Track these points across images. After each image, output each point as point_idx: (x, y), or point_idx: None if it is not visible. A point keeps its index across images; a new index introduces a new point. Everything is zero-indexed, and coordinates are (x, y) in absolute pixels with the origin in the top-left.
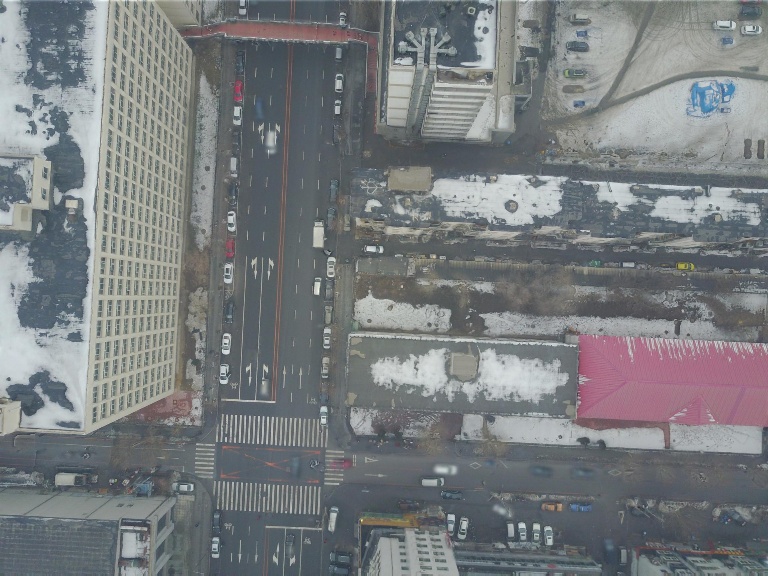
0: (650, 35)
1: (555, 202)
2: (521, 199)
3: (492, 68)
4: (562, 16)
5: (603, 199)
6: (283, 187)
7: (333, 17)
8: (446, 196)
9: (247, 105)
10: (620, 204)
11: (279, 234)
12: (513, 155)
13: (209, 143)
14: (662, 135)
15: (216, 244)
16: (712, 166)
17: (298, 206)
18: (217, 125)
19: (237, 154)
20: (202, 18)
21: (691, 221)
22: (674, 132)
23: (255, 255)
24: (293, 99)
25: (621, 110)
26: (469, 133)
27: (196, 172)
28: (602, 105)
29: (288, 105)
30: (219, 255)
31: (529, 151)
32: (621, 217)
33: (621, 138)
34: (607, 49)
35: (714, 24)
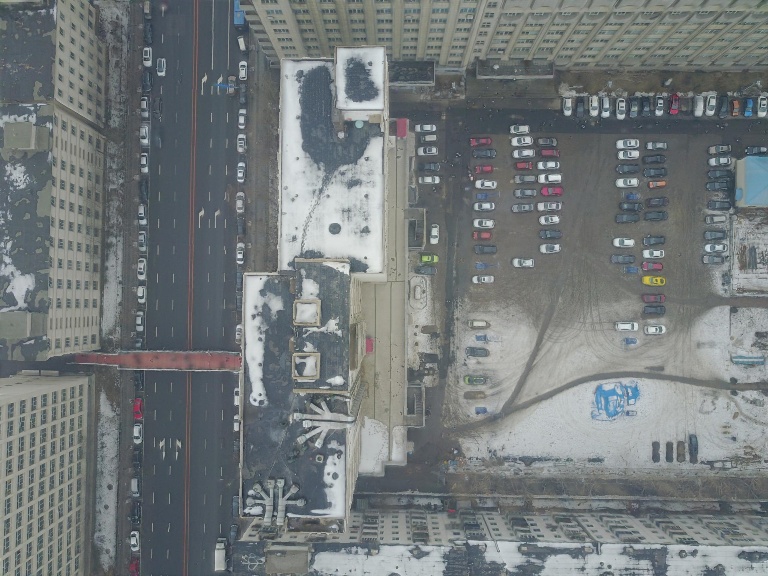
0: (551, 337)
1: (439, 573)
2: (404, 571)
3: (342, 516)
4: (461, 320)
5: (491, 560)
6: (186, 503)
7: (230, 328)
8: (328, 570)
9: (147, 421)
10: (508, 565)
11: (183, 552)
12: (416, 465)
13: (111, 461)
14: (567, 440)
15: (120, 565)
16: (619, 471)
17: (201, 522)
18: (118, 443)
19: (139, 471)
20: (100, 335)
21: None
22: (579, 437)
23: (160, 573)
24: (193, 413)
25: (524, 415)
26: (363, 466)
27: (99, 491)
28: (505, 411)
29: (188, 420)
30: (124, 575)
31: (432, 460)
32: None
33: (525, 444)
34: (508, 353)
35: (615, 327)
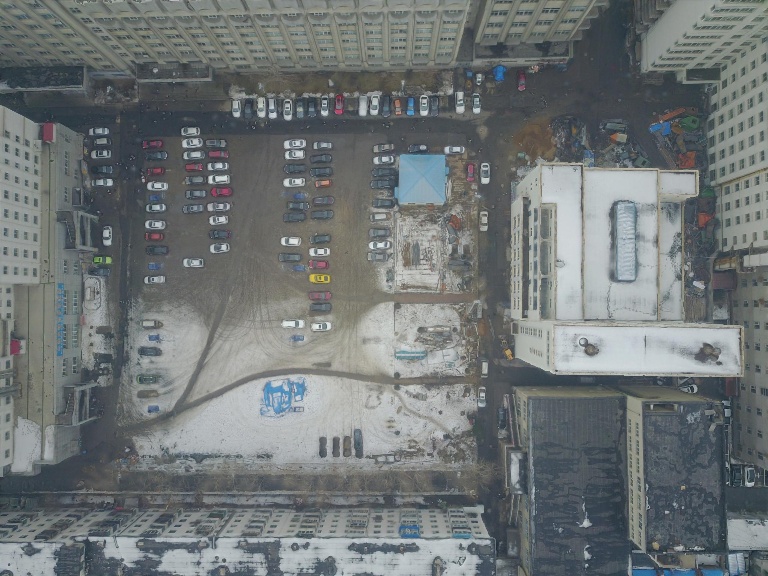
0: (222, 335)
1: (50, 570)
2: (16, 568)
3: None
4: (134, 320)
5: (110, 555)
6: None
7: None
8: None
9: None
10: (126, 560)
11: None
12: (91, 463)
13: None
14: (237, 437)
15: None
16: (287, 467)
17: None
18: None
19: None
20: None
21: (198, 574)
22: (249, 433)
23: None
24: None
25: (196, 413)
26: (16, 465)
27: None
28: (177, 409)
29: None
30: None
31: (106, 459)
32: (128, 573)
33: (197, 441)
34: (180, 352)
35: (281, 324)
